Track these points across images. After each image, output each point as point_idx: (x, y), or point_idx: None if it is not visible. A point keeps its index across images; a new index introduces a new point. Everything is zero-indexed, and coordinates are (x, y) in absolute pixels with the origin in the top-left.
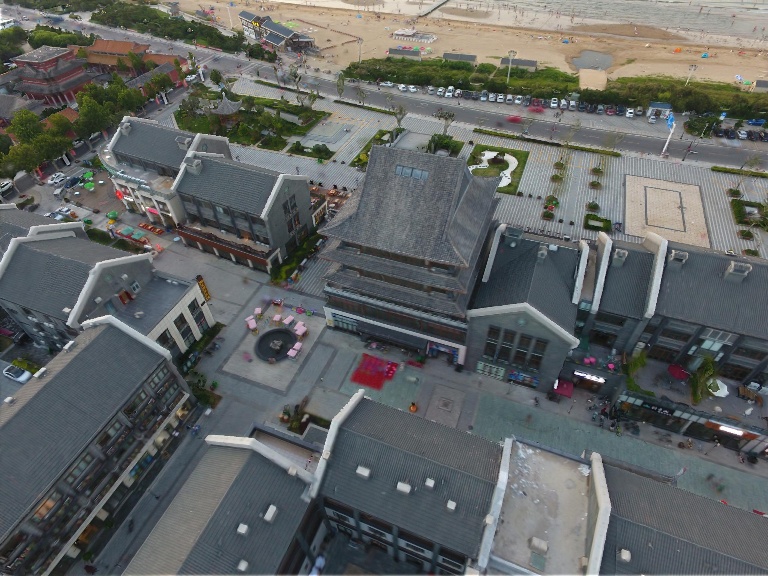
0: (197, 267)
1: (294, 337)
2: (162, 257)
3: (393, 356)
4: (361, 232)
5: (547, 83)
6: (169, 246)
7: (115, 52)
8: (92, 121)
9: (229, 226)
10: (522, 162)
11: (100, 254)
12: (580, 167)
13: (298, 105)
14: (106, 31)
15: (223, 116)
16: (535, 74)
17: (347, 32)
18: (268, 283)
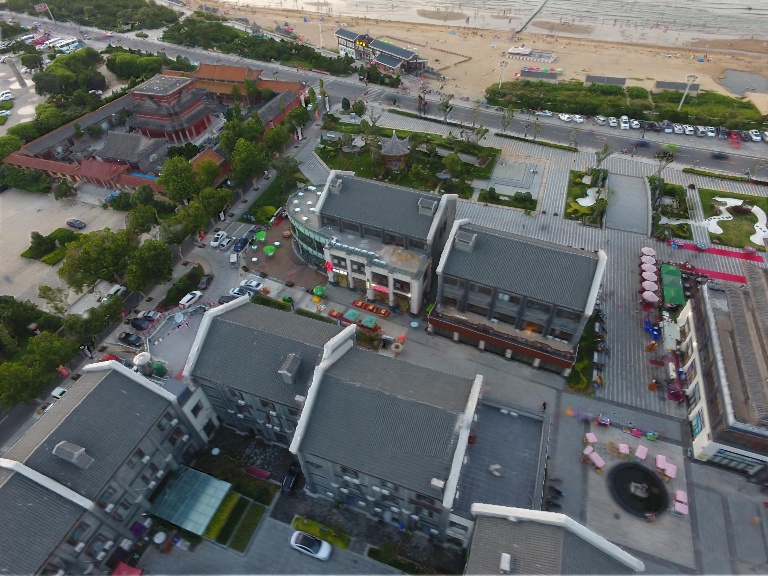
0: (460, 365)
1: (656, 477)
2: (407, 350)
3: None
4: None
5: (728, 111)
6: (407, 334)
7: (226, 79)
8: (249, 167)
9: (508, 315)
10: None
11: (426, 382)
12: None
13: (455, 139)
14: (184, 51)
15: None
16: (701, 99)
17: (451, 50)
18: (566, 389)
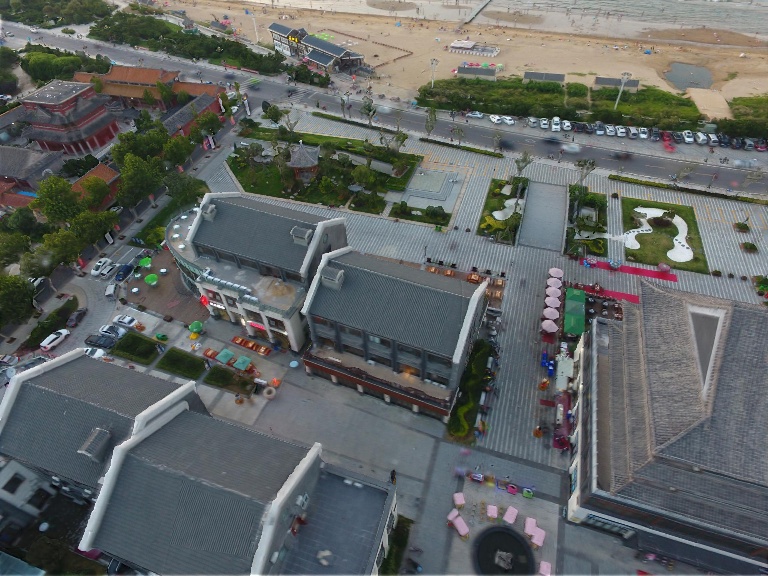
0: (336, 411)
1: (525, 543)
2: (281, 395)
3: (683, 574)
4: (727, 452)
5: (665, 109)
6: (285, 375)
7: (138, 82)
8: (139, 185)
9: (384, 358)
10: (692, 223)
11: (250, 457)
12: (767, 228)
13: (377, 146)
14: (110, 49)
15: (298, 168)
16: (640, 96)
17: (393, 44)
18: (446, 437)
